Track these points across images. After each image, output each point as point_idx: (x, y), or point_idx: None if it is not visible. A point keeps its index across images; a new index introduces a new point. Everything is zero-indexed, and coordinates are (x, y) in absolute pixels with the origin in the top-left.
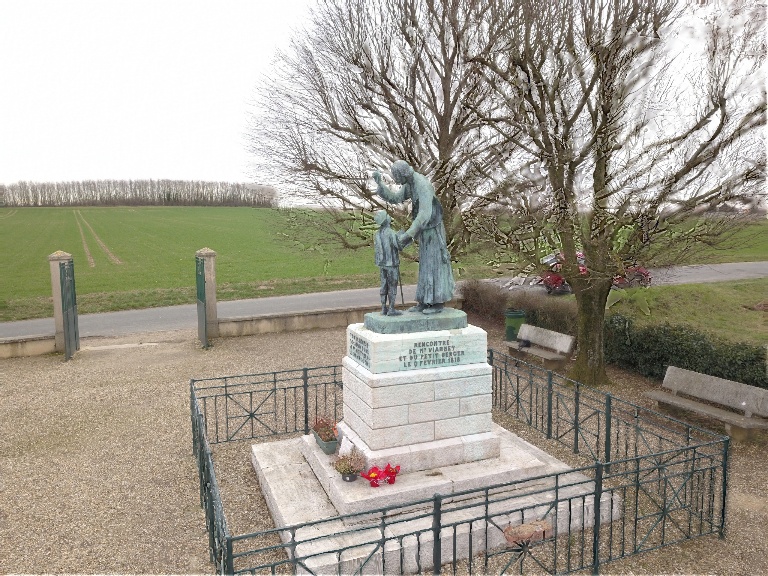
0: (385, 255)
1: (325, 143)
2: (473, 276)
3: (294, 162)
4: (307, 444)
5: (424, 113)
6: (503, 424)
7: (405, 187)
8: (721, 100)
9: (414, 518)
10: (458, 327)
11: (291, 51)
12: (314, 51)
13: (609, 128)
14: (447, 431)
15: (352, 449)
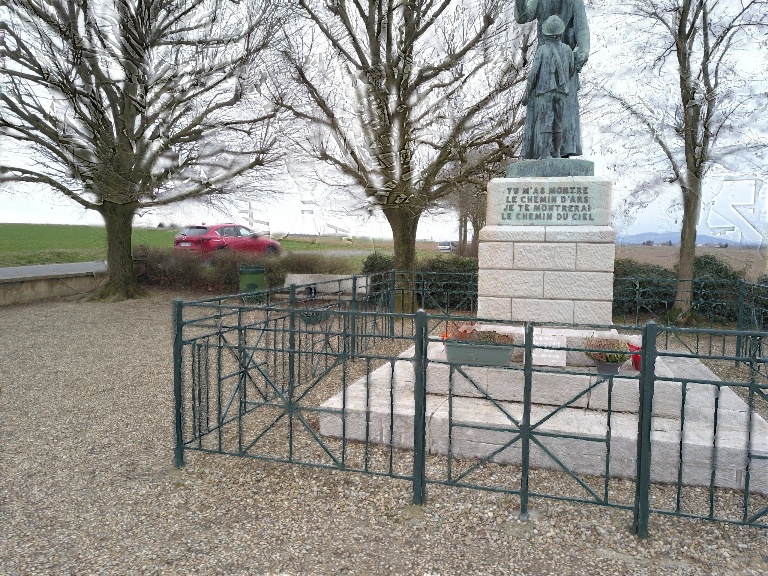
0: None
1: None
2: (171, 232)
3: None
4: (442, 369)
5: None
6: None
7: (538, 2)
8: (526, 46)
9: None
10: None
11: None
12: None
13: (485, 41)
14: None
15: (566, 341)
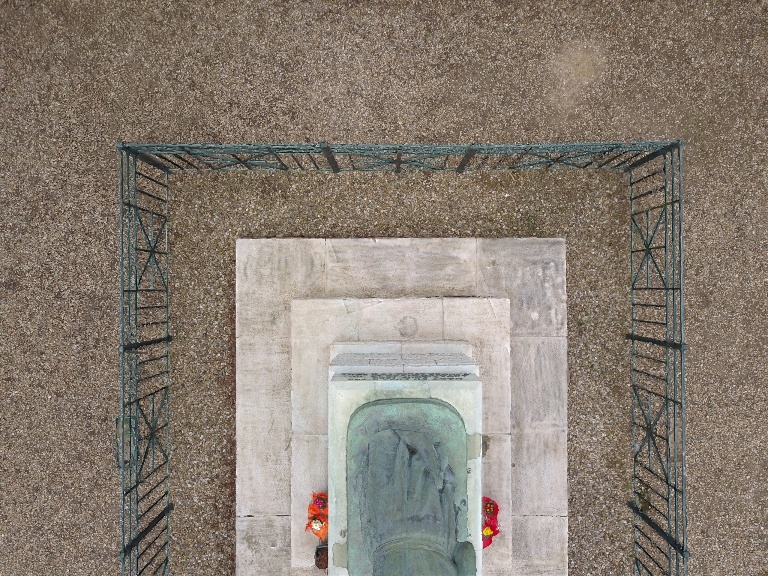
0: None
1: None
2: None
3: None
4: None
5: None
6: (255, 200)
7: None
8: None
9: None
10: None
11: None
12: None
13: None
14: None
15: None
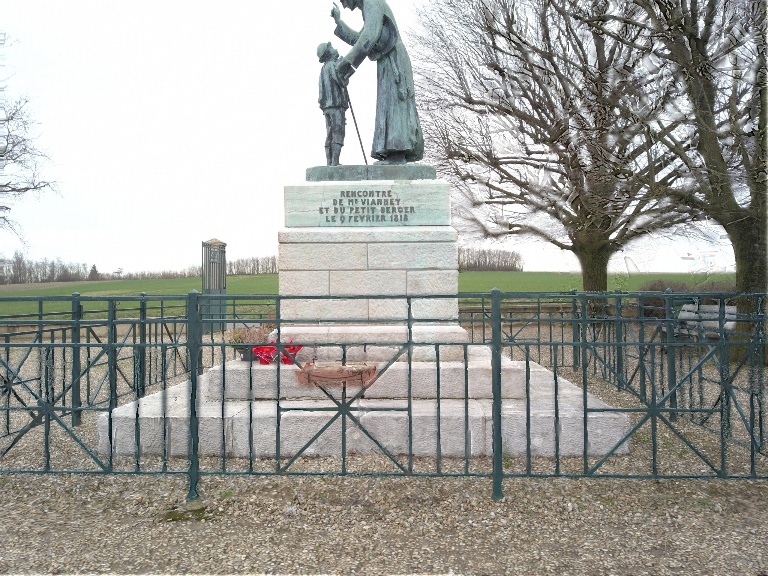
0: (326, 95)
1: (443, 108)
2: (642, 265)
3: (438, 151)
4: None
5: (572, 74)
6: (570, 380)
7: None
8: None
9: (157, 322)
10: (412, 179)
11: (426, 31)
12: (446, 25)
13: None
14: (387, 315)
15: None
